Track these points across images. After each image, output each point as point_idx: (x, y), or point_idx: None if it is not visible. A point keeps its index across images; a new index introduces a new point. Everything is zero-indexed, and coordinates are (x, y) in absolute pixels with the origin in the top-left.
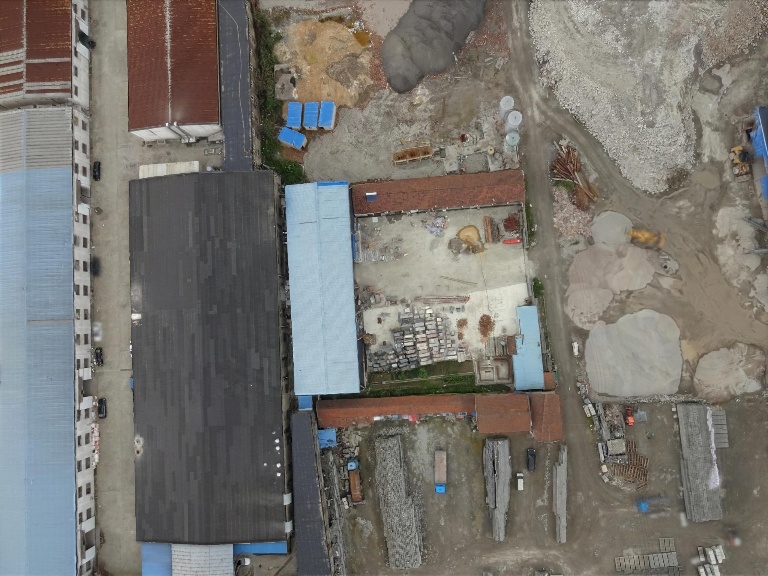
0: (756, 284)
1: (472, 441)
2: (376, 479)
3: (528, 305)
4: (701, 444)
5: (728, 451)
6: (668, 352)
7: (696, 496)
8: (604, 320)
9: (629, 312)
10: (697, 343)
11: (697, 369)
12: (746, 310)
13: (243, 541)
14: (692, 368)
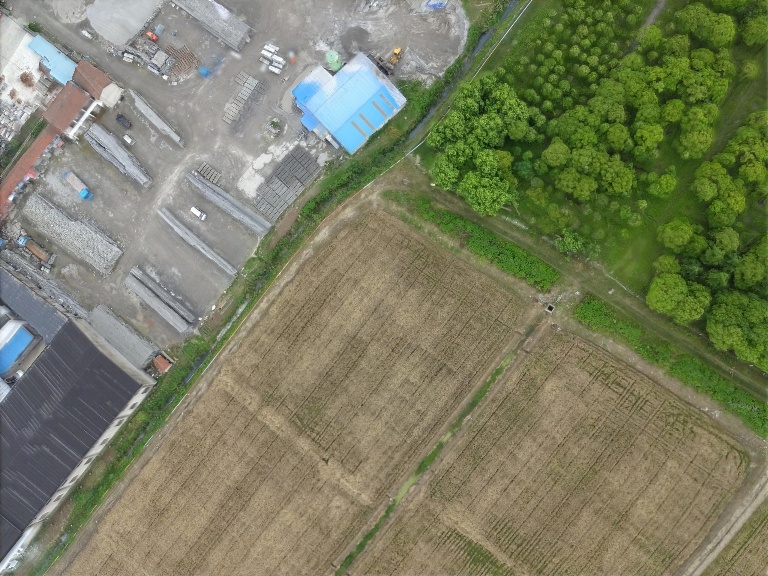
0: None
1: (83, 150)
2: None
3: (33, 39)
4: (197, 2)
5: None
6: None
7: (222, 31)
8: (89, 3)
9: None
10: None
11: None
12: None
13: None
14: None
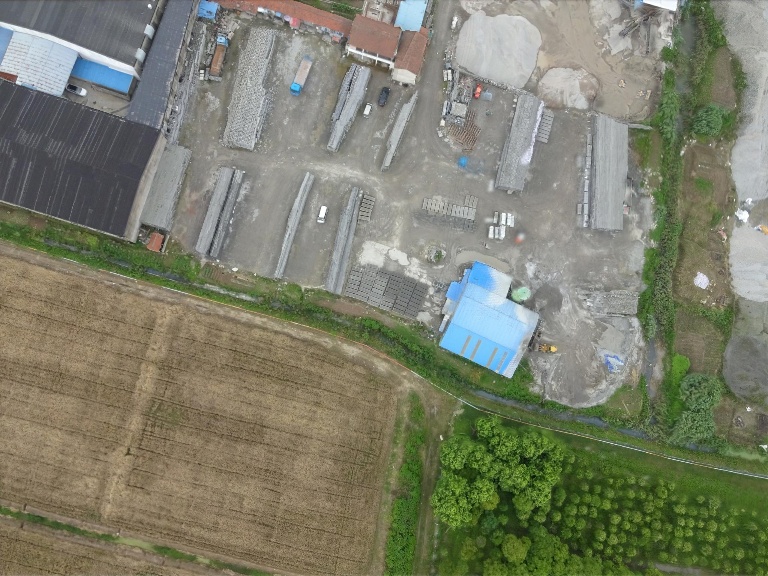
0: (611, 31)
1: (338, 65)
2: (240, 58)
3: None
4: (527, 127)
5: (545, 147)
6: (527, 49)
7: (508, 165)
8: (485, 11)
9: (507, 13)
10: (551, 57)
11: (544, 76)
12: (597, 47)
13: (90, 48)
14: (541, 74)
